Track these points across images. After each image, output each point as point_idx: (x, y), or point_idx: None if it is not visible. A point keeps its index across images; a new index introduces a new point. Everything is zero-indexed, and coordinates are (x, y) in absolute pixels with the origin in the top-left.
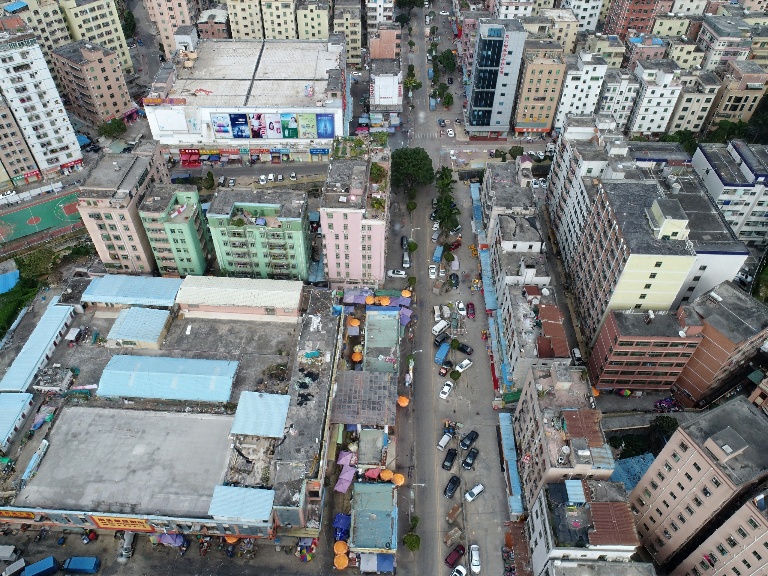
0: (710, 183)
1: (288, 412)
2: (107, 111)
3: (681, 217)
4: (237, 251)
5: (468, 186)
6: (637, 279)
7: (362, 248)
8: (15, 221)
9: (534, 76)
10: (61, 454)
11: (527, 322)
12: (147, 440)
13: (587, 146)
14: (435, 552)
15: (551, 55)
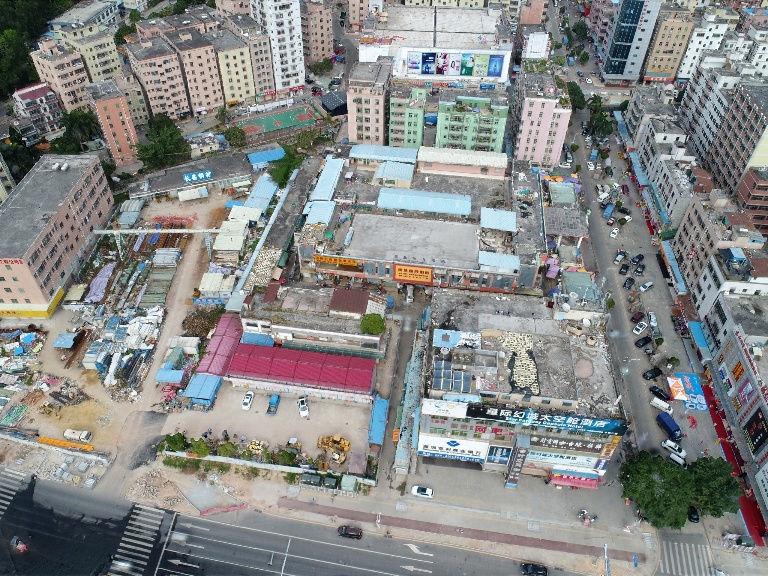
0: None
1: (516, 220)
2: (317, 54)
3: None
4: (453, 134)
5: (609, 116)
6: None
7: (549, 134)
8: (264, 123)
9: (666, 32)
10: (363, 236)
11: (682, 180)
12: (419, 232)
13: (723, 68)
14: (622, 315)
15: (680, 16)
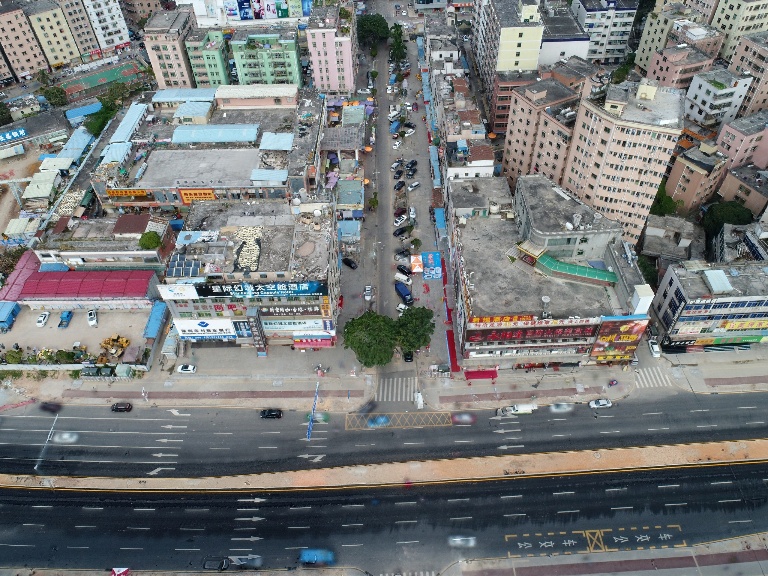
0: (580, 14)
1: (293, 140)
2: (143, 10)
3: (533, 4)
4: (252, 71)
5: (416, 43)
6: (510, 49)
7: (337, 62)
8: (89, 81)
9: None
10: (156, 169)
11: (445, 90)
12: (207, 161)
13: None
14: (389, 213)
15: None
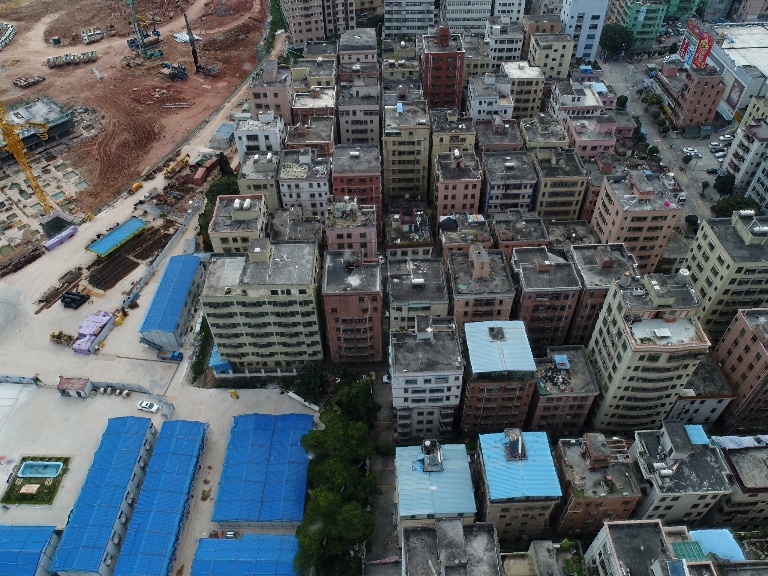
0: None
1: None
2: None
3: None
4: None
5: None
6: None
7: None
8: None
9: None
10: None
11: None
12: None
13: None
14: None
15: None
